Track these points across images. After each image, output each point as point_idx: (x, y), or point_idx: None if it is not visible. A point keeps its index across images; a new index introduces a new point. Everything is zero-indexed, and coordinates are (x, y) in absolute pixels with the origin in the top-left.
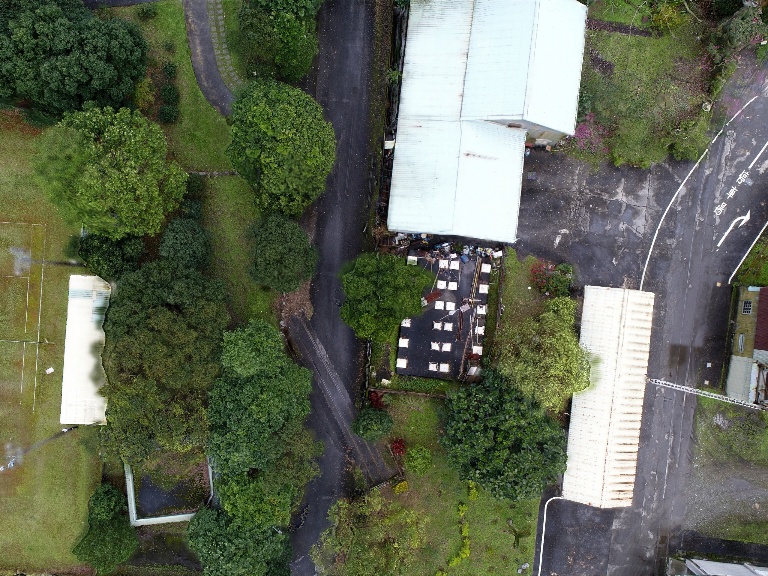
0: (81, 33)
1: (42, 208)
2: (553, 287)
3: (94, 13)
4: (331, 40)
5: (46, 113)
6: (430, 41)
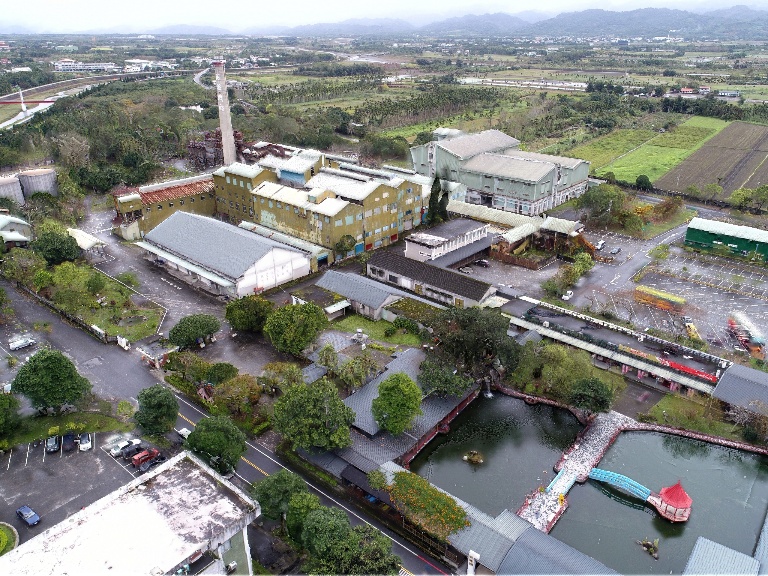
0: None
1: None
2: None
3: None
4: None
5: None
6: None
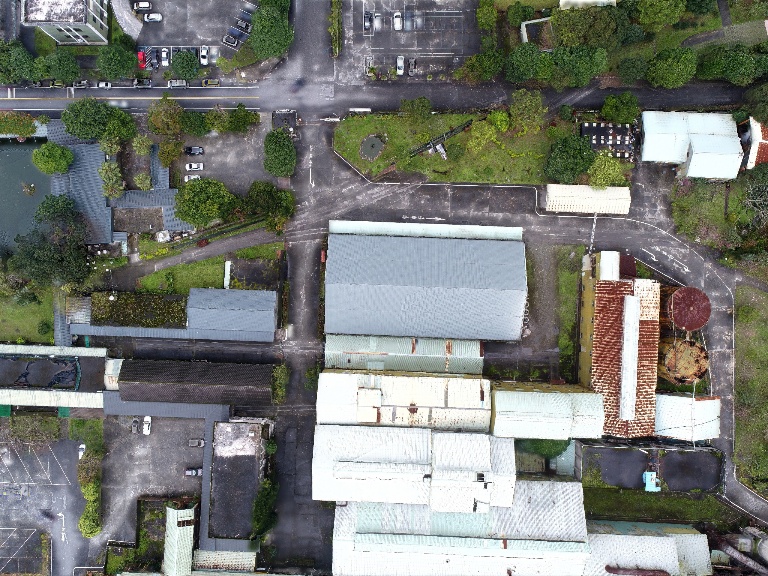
0: None
1: None
2: None
3: None
4: (711, 89)
5: None
6: (717, 121)
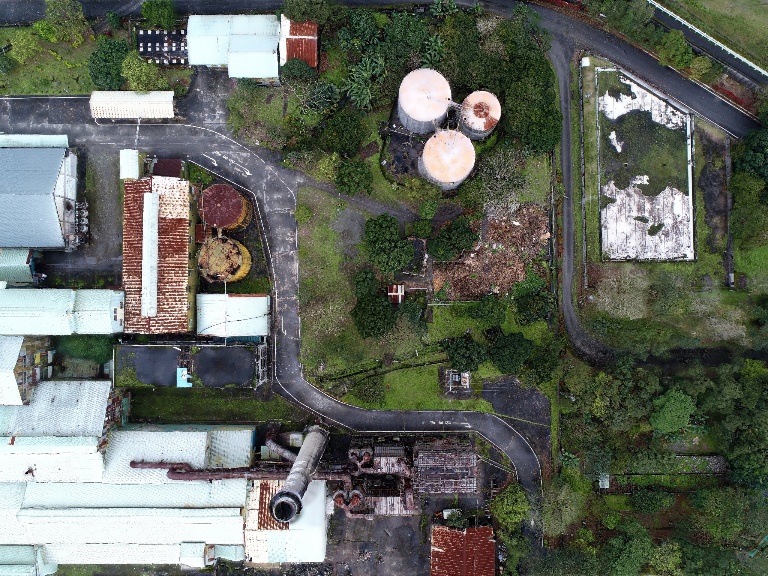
0: None
1: None
2: (177, 87)
3: None
4: None
5: None
6: (261, 22)
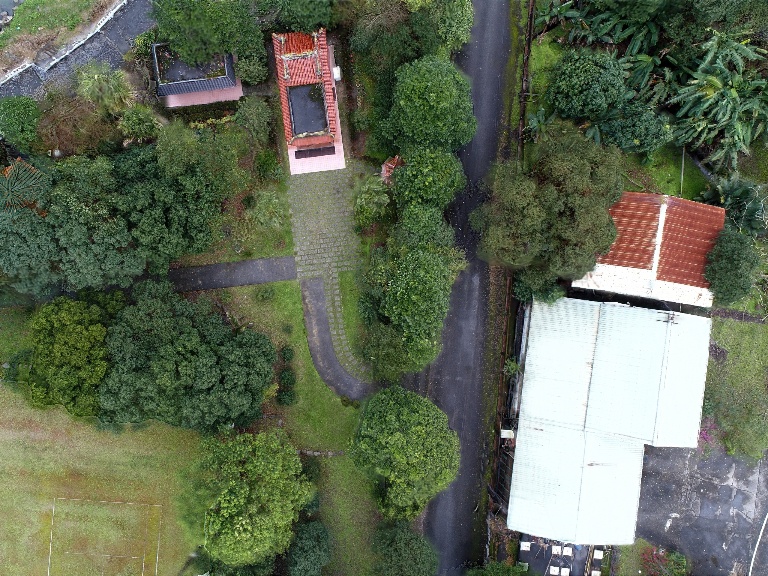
0: (222, 370)
1: (158, 489)
2: None
3: (212, 292)
4: None
5: (175, 423)
6: (553, 345)
